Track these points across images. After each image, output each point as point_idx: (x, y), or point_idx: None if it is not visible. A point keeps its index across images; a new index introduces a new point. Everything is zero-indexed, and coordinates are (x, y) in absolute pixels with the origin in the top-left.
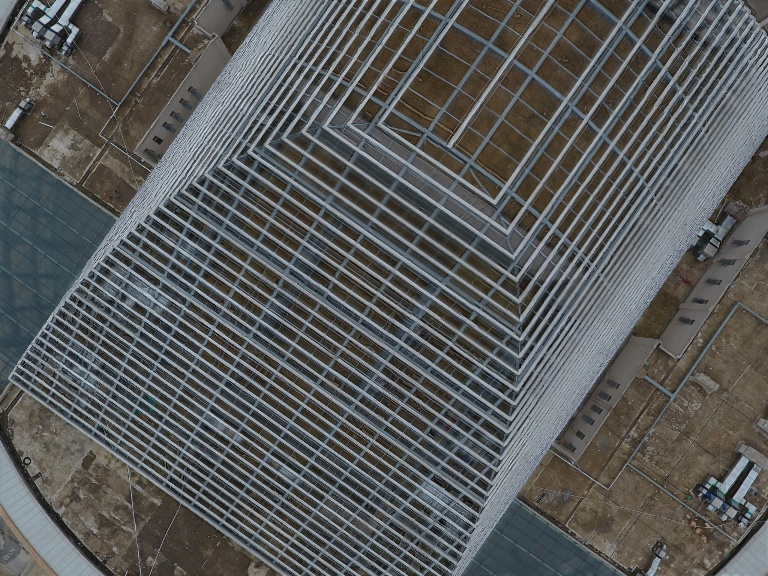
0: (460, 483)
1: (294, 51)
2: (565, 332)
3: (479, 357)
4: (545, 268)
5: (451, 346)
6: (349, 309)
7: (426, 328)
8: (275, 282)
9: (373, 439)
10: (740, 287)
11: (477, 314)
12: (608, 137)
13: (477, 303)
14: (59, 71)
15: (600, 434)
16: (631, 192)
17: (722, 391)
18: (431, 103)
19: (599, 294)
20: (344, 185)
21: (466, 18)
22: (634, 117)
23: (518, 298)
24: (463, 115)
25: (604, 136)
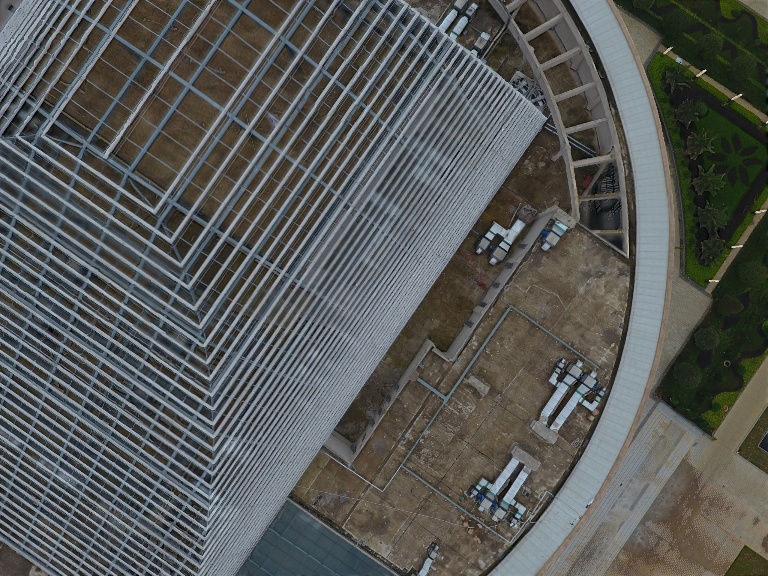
0: (186, 487)
1: None
2: (263, 338)
3: (175, 363)
4: (221, 276)
5: (148, 352)
6: (56, 317)
7: (123, 335)
8: None
9: (104, 444)
10: (514, 290)
11: (164, 321)
12: (278, 147)
13: (161, 310)
14: None
15: (376, 437)
16: (316, 200)
17: (496, 393)
18: (92, 115)
19: (300, 300)
20: (26, 195)
21: (127, 31)
22: (304, 127)
23: (193, 305)
24: (121, 126)
25: (273, 146)
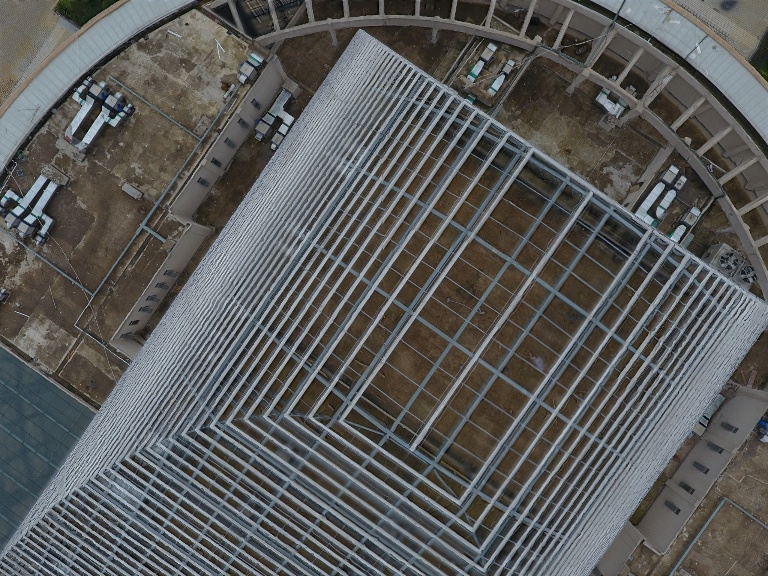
0: None
1: (258, 313)
2: None
3: None
4: None
5: None
6: (317, 569)
7: None
8: (243, 536)
9: None
10: (727, 480)
11: None
12: (578, 424)
13: None
14: (34, 259)
15: None
16: (604, 466)
17: None
18: (394, 401)
19: None
20: (308, 466)
21: (429, 312)
22: (605, 403)
23: None
24: (426, 416)
25: (574, 425)
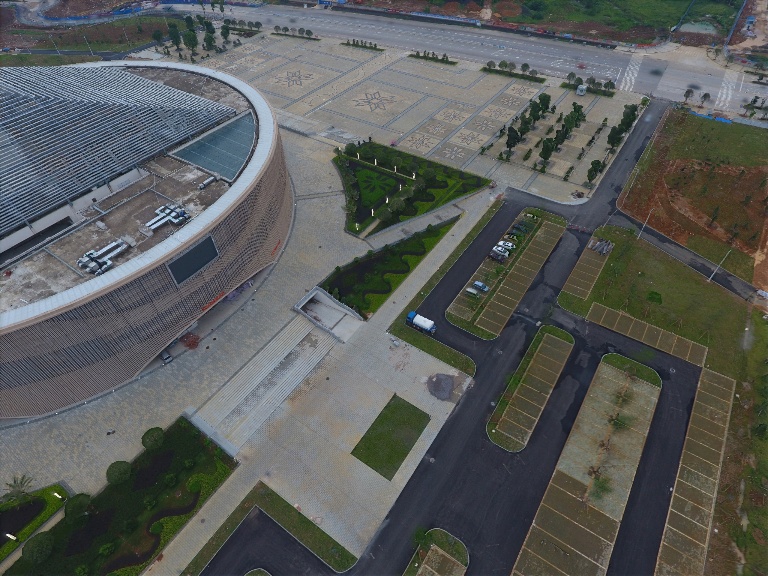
0: None
1: None
2: None
3: None
4: None
5: None
6: None
7: None
8: None
9: None
10: None
11: None
12: None
13: None
14: None
15: None
16: None
17: None
18: None
19: None
20: None
21: None
22: None
23: None
24: None
25: None
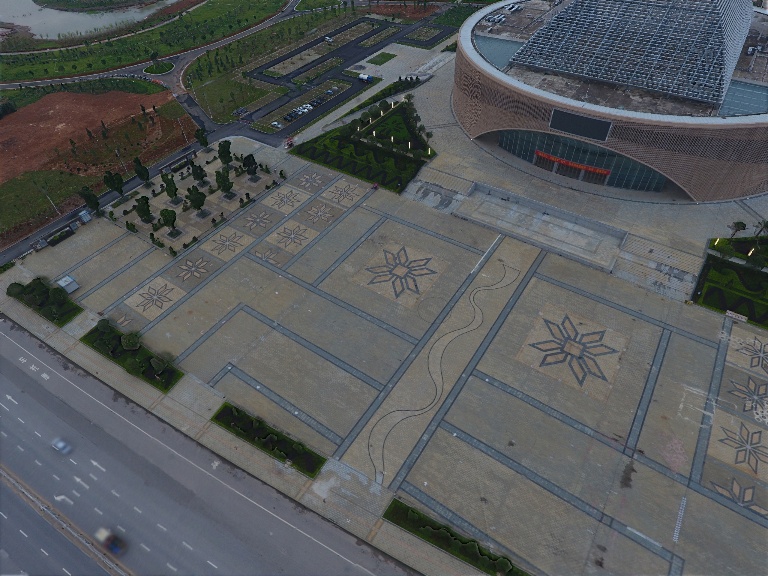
0: None
1: None
2: None
3: None
4: None
5: None
6: (651, 1)
7: None
8: (623, 2)
9: None
10: None
11: None
12: None
13: None
14: None
15: None
16: None
17: None
18: None
19: None
20: None
21: None
22: None
23: None
24: None
25: None
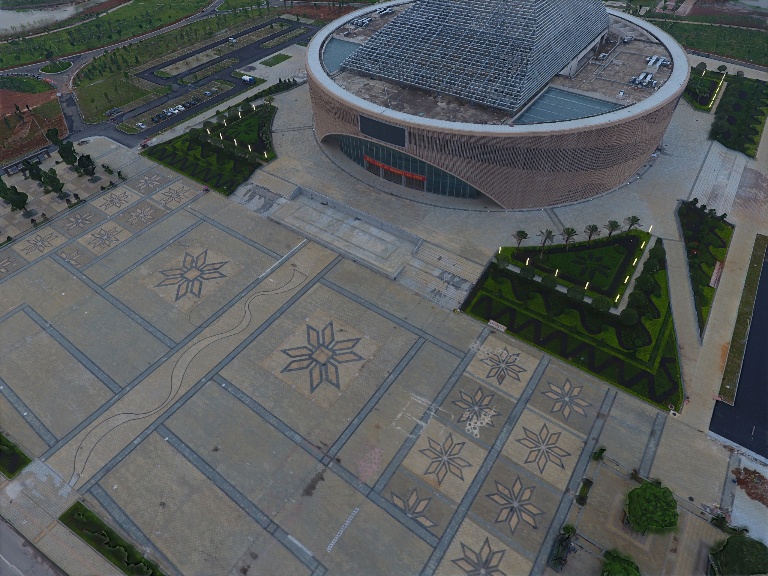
0: None
1: None
2: (547, 4)
3: None
4: None
5: (512, 5)
6: (479, 6)
7: (504, 3)
8: None
9: None
10: None
11: None
12: None
13: None
14: None
15: None
16: None
17: None
18: None
19: (555, 2)
20: None
21: None
22: None
23: None
24: None
25: None
